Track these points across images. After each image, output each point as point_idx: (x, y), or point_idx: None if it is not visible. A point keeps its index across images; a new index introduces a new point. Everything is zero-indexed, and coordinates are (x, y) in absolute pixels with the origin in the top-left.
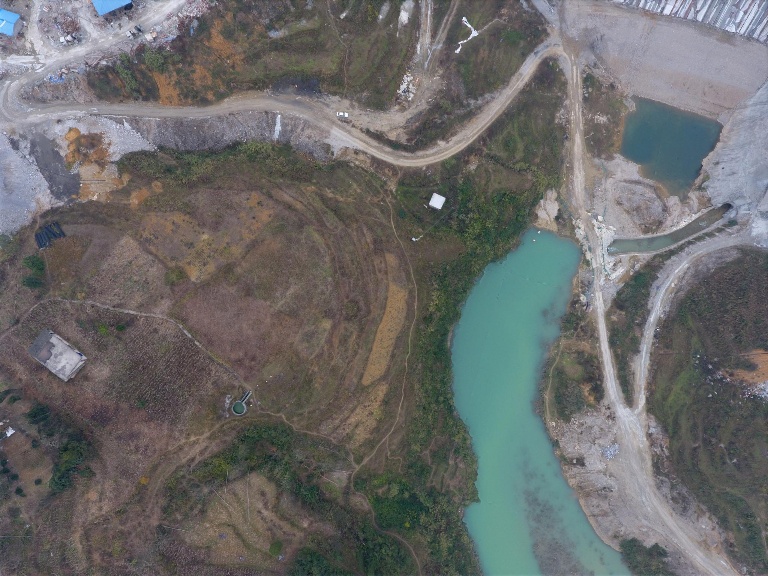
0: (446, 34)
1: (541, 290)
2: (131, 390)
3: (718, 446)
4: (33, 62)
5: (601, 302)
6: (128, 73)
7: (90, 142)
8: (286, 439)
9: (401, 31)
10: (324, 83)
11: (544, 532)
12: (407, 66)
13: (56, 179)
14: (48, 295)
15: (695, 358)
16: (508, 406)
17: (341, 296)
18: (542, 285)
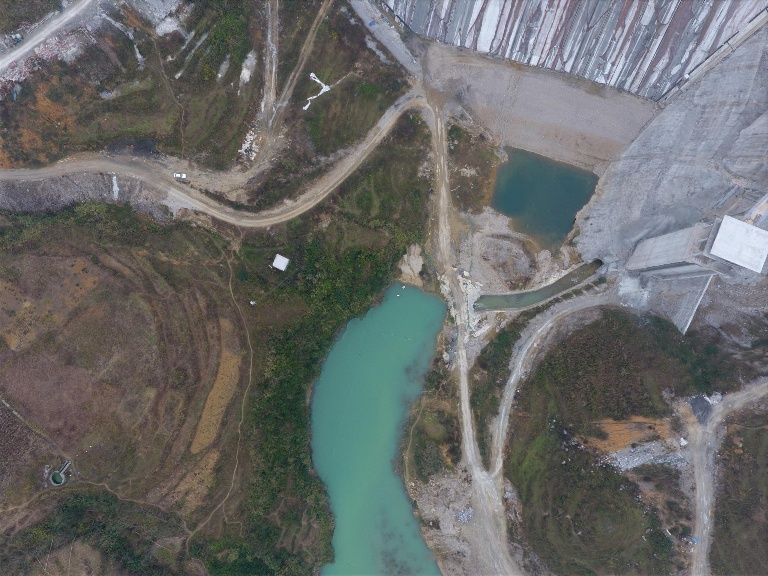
0: (292, 91)
1: (406, 346)
2: None
3: (564, 517)
4: None
5: (464, 360)
6: None
7: None
8: (110, 508)
9: (242, 89)
10: (160, 144)
11: None
12: (250, 125)
13: None
14: None
15: (551, 423)
16: (369, 464)
17: (167, 364)
18: (407, 341)
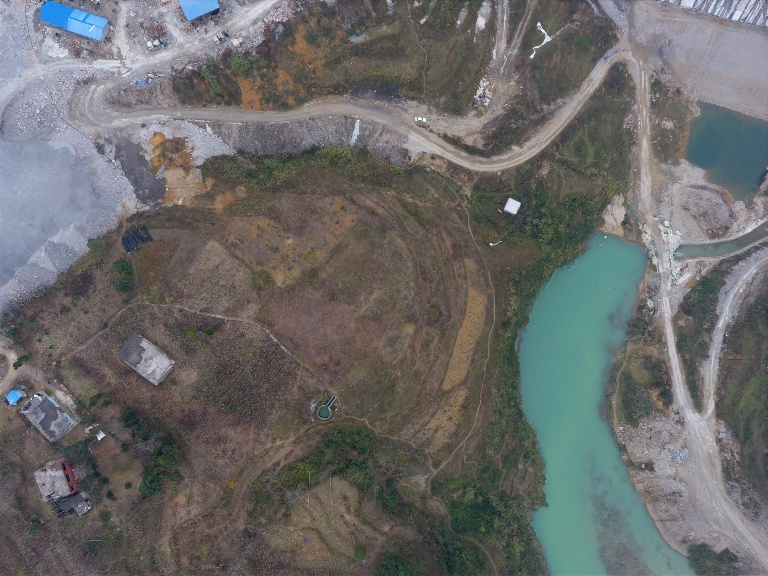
0: (521, 39)
1: (607, 295)
2: (218, 394)
3: None
4: (119, 67)
5: (668, 307)
6: (213, 78)
7: (175, 146)
8: (369, 443)
9: (478, 36)
10: (403, 88)
11: (611, 537)
12: (483, 71)
13: (141, 183)
14: (136, 299)
15: (766, 364)
16: (574, 410)
17: (423, 301)
18: (608, 290)
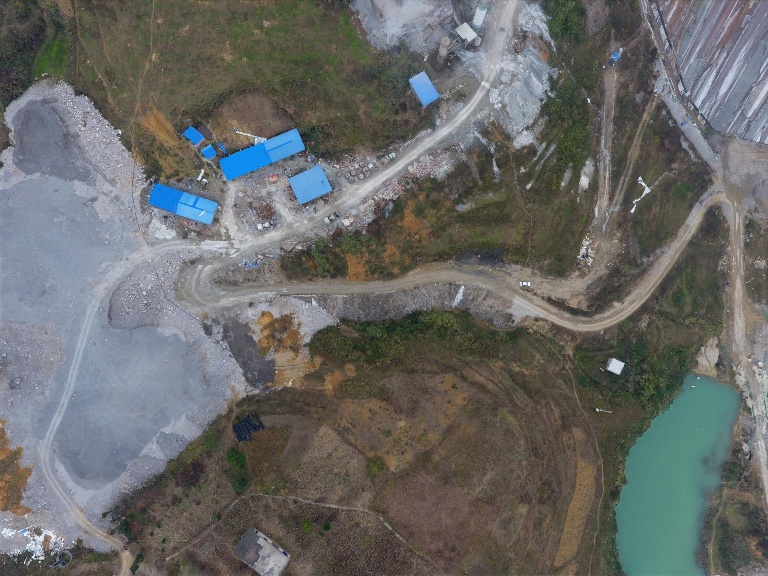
0: (623, 195)
1: (700, 436)
2: None
3: None
4: (228, 247)
5: (764, 451)
6: (323, 257)
7: (283, 326)
8: None
9: (582, 196)
10: (508, 254)
11: None
12: None
13: (250, 365)
14: (250, 490)
15: None
16: (669, 556)
17: (535, 479)
18: (700, 431)
